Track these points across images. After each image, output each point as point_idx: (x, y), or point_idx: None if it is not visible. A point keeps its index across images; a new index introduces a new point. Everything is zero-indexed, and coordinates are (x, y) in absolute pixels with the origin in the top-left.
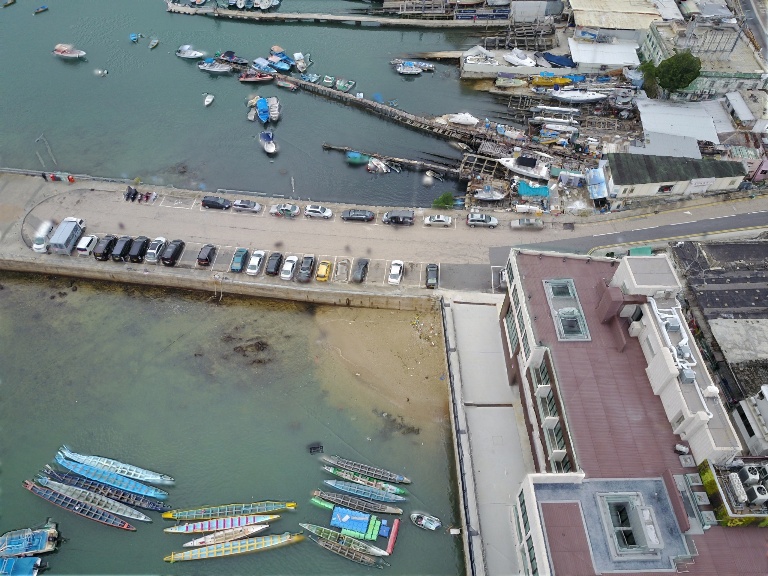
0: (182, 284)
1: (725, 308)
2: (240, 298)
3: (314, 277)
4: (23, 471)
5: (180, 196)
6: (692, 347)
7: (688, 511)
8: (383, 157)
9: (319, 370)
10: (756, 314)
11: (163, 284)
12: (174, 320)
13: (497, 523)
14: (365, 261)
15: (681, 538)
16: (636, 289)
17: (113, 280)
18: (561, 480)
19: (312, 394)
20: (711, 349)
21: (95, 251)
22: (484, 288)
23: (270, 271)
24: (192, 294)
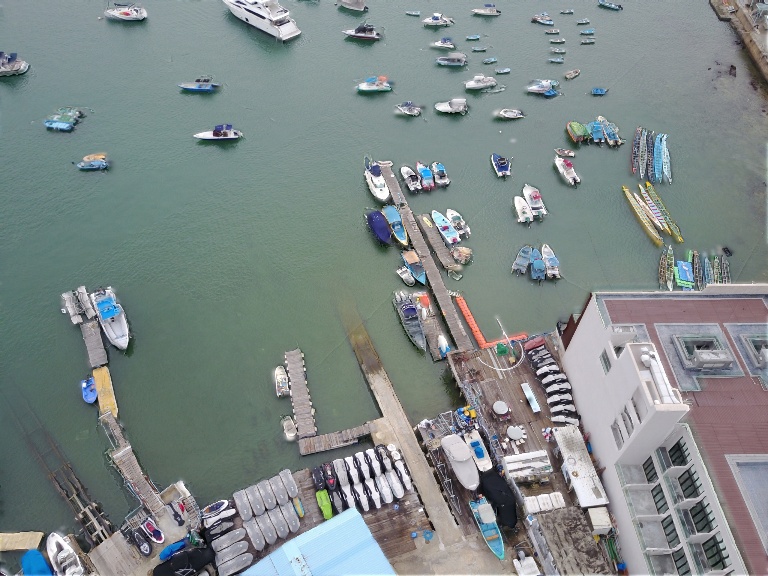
0: None
1: None
2: None
3: None
4: (646, 124)
5: None
6: None
7: None
8: None
9: None
10: None
11: None
12: None
13: None
14: None
15: None
16: None
17: None
18: None
19: None
20: None
21: None
22: None
23: None
24: None
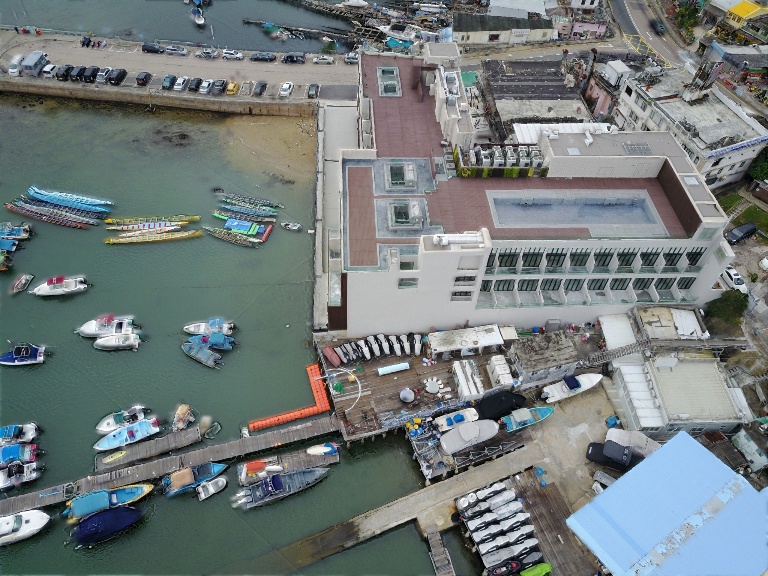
0: (125, 98)
1: (509, 94)
2: (169, 110)
3: (225, 93)
4: (4, 198)
5: (125, 45)
6: (461, 90)
7: (441, 172)
8: (290, 28)
9: (225, 150)
10: (529, 97)
11: (110, 99)
12: (118, 122)
13: (336, 217)
14: (265, 84)
15: (433, 182)
16: (430, 58)
17: (71, 97)
18: (362, 156)
19: (219, 163)
20: (494, 116)
21: (57, 72)
22: (351, 98)
23: (192, 87)
24: (132, 107)
